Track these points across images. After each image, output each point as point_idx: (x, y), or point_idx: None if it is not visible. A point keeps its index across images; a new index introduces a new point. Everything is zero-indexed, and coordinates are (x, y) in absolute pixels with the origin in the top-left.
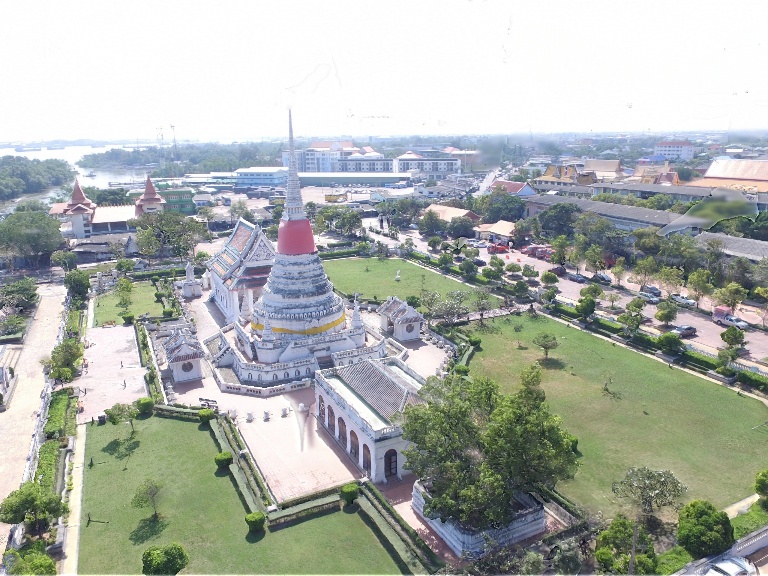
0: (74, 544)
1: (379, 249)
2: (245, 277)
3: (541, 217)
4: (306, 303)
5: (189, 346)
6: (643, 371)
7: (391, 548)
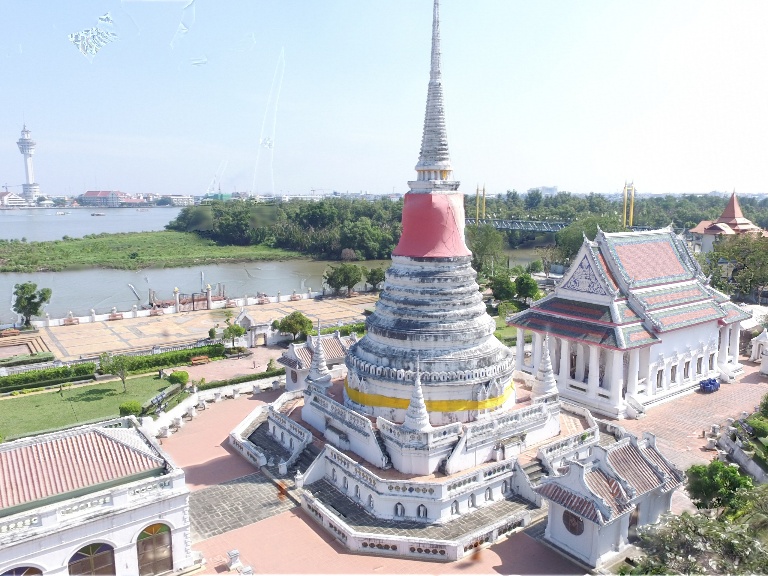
0: None
1: None
2: (541, 310)
3: None
4: (374, 343)
5: (306, 352)
6: None
7: None
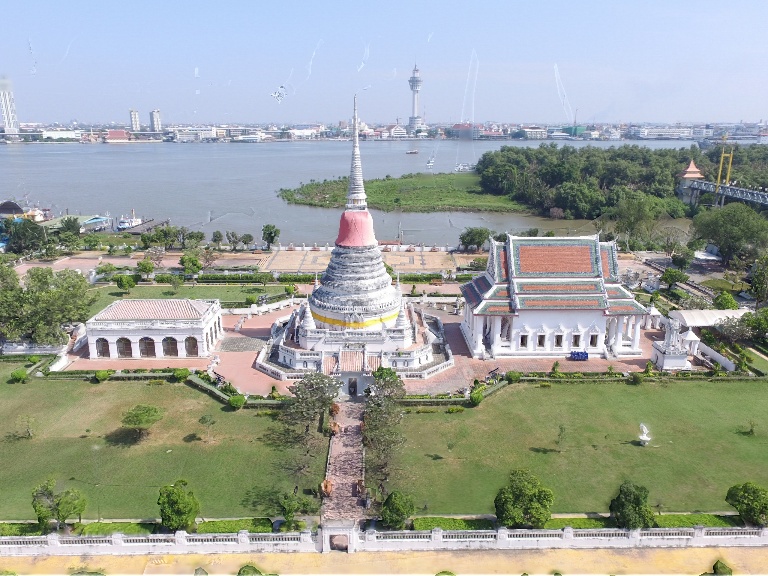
0: None
1: None
2: None
3: None
4: None
5: None
6: None
7: None
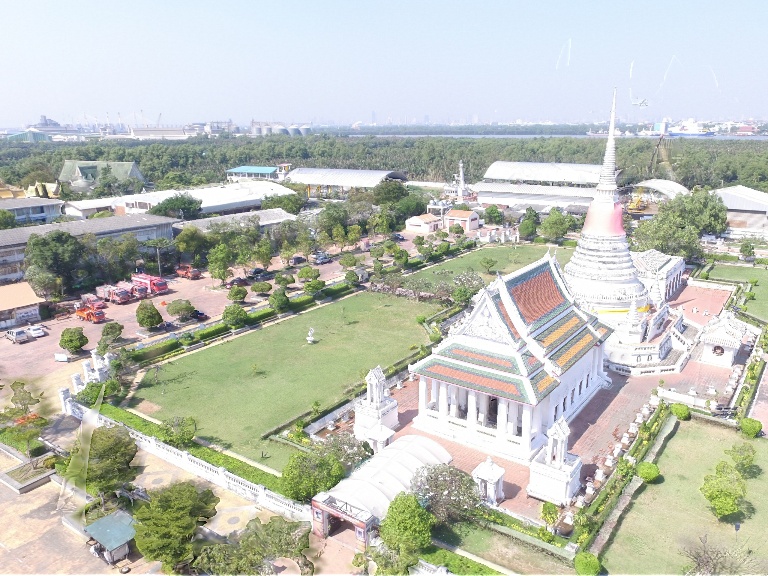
0: None
1: None
2: None
3: (54, 258)
4: None
5: None
6: None
7: (707, 272)
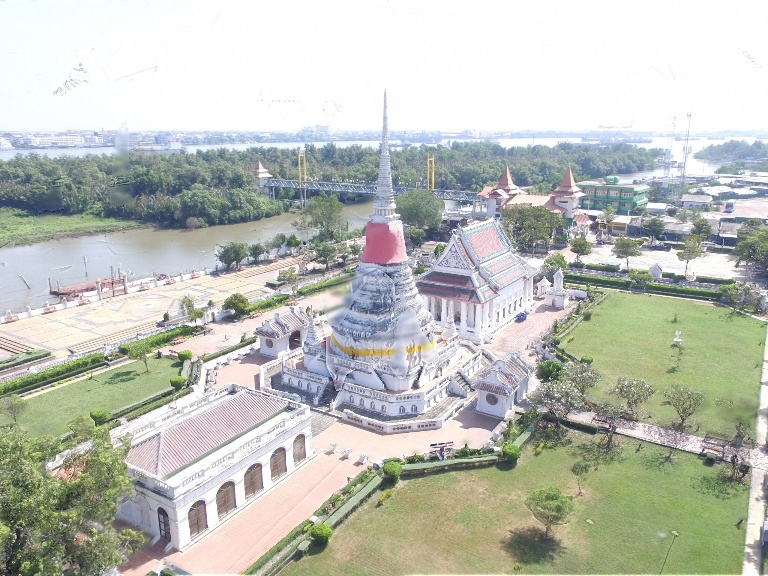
0: None
1: (745, 299)
2: (426, 281)
3: None
4: None
5: (277, 325)
6: None
7: None
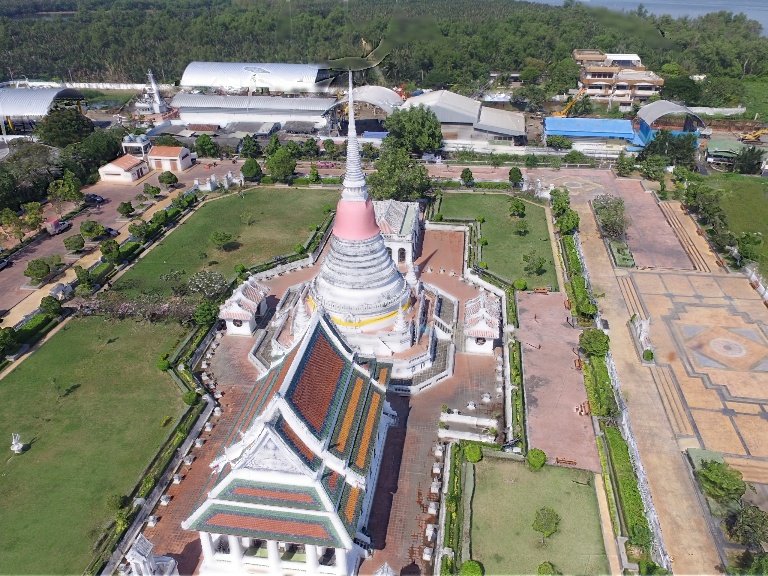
0: (552, 235)
1: None
2: None
3: None
4: None
5: None
6: (202, 227)
7: None
